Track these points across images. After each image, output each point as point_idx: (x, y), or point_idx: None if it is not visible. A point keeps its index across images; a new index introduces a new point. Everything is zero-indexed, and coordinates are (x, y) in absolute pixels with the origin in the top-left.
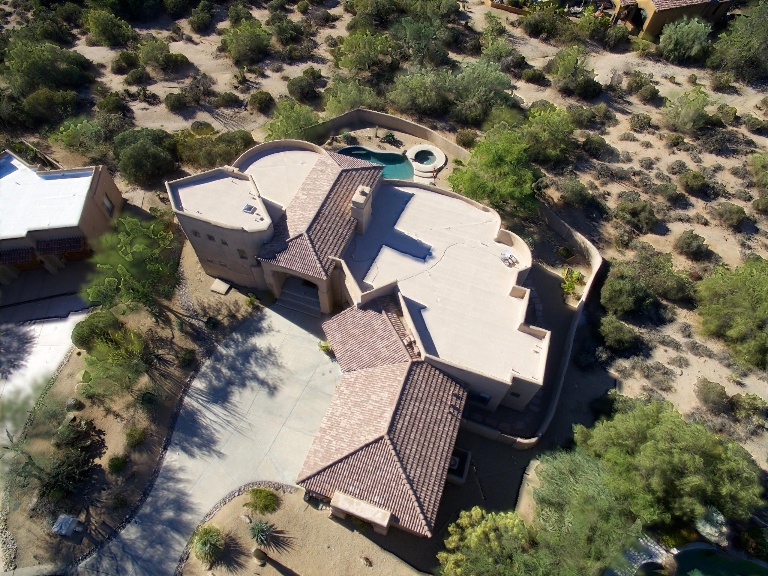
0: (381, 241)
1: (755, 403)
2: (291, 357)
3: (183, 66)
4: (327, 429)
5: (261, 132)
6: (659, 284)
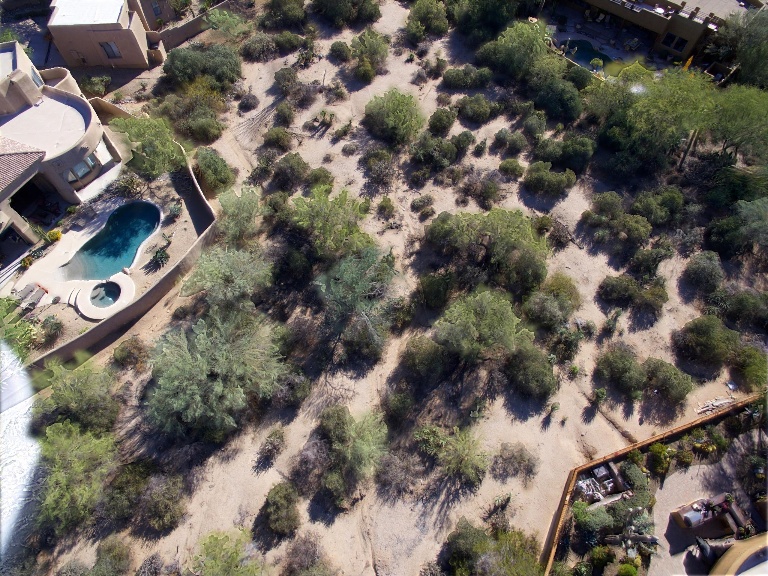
0: None
1: None
2: None
3: (358, 76)
4: None
5: (233, 147)
6: None
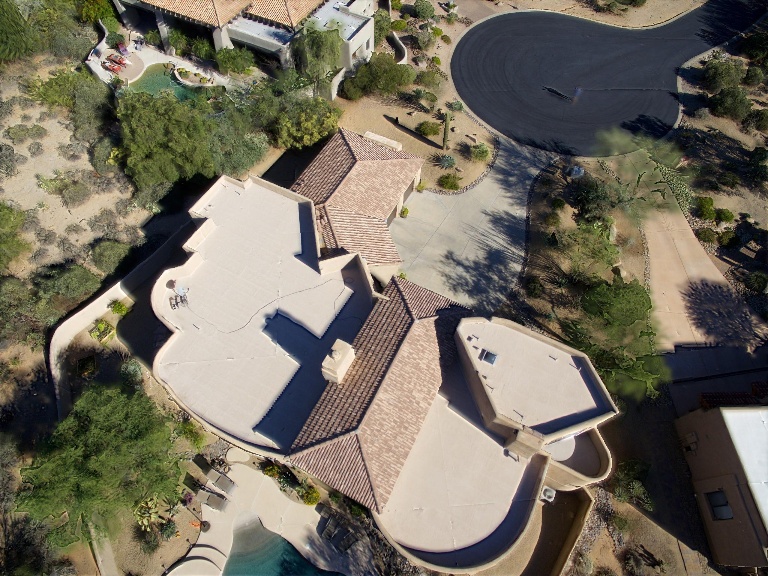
0: (323, 345)
1: (50, 182)
2: (434, 280)
3: None
4: (402, 183)
5: None
6: (22, 291)
